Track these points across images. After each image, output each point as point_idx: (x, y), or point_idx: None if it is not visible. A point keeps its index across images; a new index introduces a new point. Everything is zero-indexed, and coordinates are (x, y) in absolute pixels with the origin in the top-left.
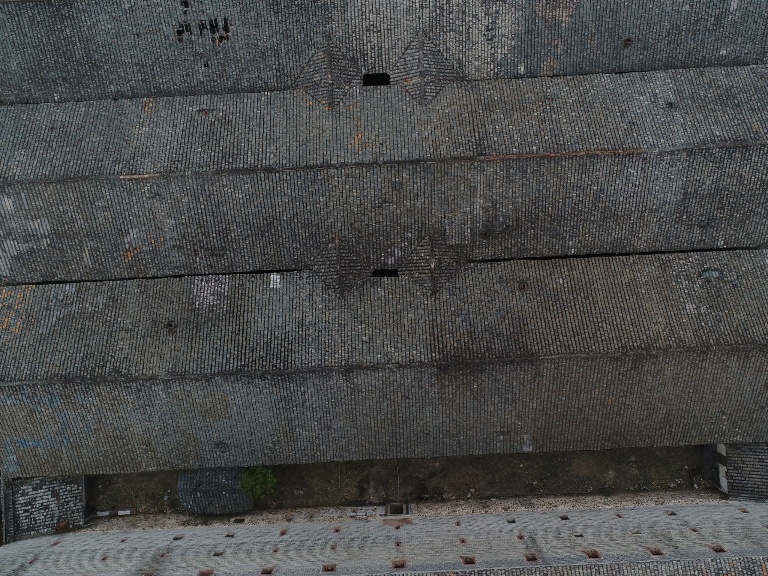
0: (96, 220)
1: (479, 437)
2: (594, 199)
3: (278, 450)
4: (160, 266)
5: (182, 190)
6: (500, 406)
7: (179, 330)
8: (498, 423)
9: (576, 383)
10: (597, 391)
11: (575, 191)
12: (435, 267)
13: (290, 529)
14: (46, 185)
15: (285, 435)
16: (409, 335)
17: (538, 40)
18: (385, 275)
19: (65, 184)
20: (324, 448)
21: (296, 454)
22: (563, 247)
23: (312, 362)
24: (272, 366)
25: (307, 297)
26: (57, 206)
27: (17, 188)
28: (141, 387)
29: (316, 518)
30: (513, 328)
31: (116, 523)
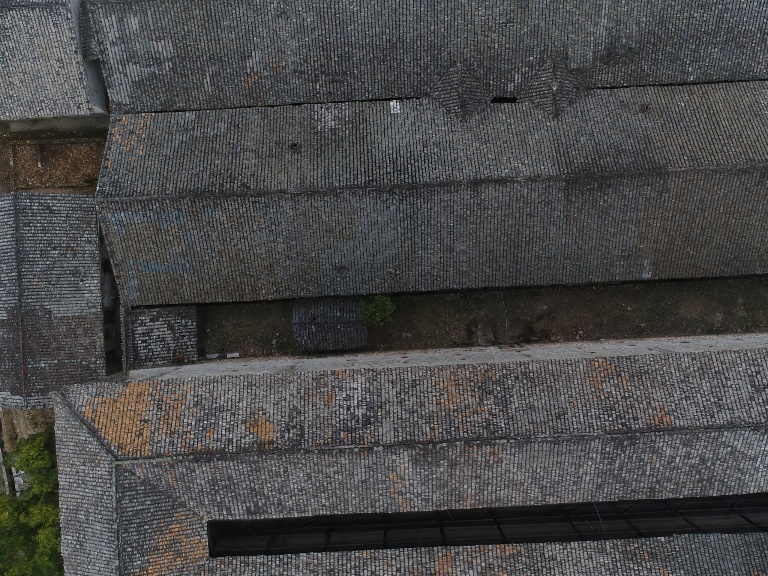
0: (220, 41)
1: (599, 262)
2: (718, 19)
3: (398, 276)
4: (280, 93)
5: (308, 8)
6: (624, 226)
7: (303, 150)
8: (620, 246)
9: (702, 200)
10: (722, 209)
11: (699, 10)
12: (557, 90)
13: (409, 356)
14: (173, 2)
15: (407, 259)
16: (535, 152)
17: None
18: (505, 101)
19: (192, 1)
20: (444, 274)
21: (416, 280)
22: (682, 73)
23: (440, 177)
24: (400, 181)
25: (429, 121)
26: (182, 26)
27: (144, 5)
28: (269, 203)
29: (431, 352)
30: (639, 145)
31: (229, 361)
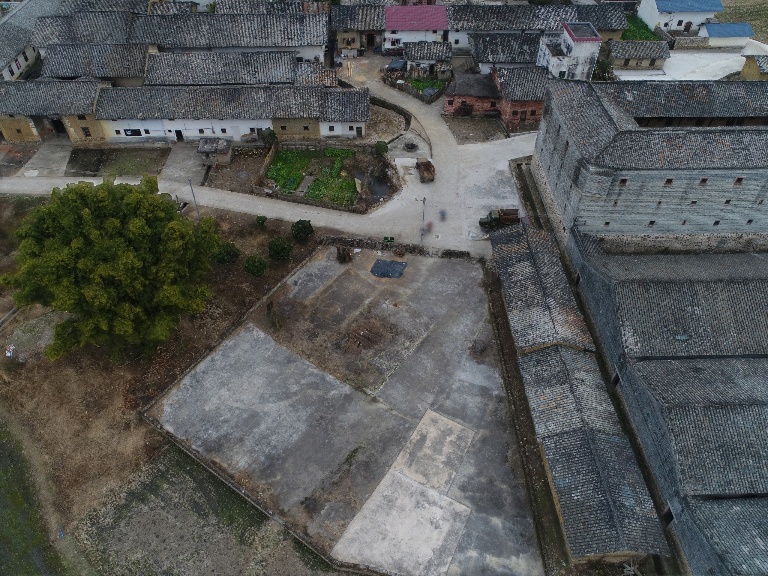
0: None
1: None
2: None
3: None
4: None
5: None
6: None
7: None
8: None
9: None
10: None
11: None
12: None
13: None
14: None
15: None
16: None
17: None
18: None
19: None
20: None
21: None
22: None
23: None
24: None
25: None
26: None
27: None
28: None
29: None
30: None
31: None
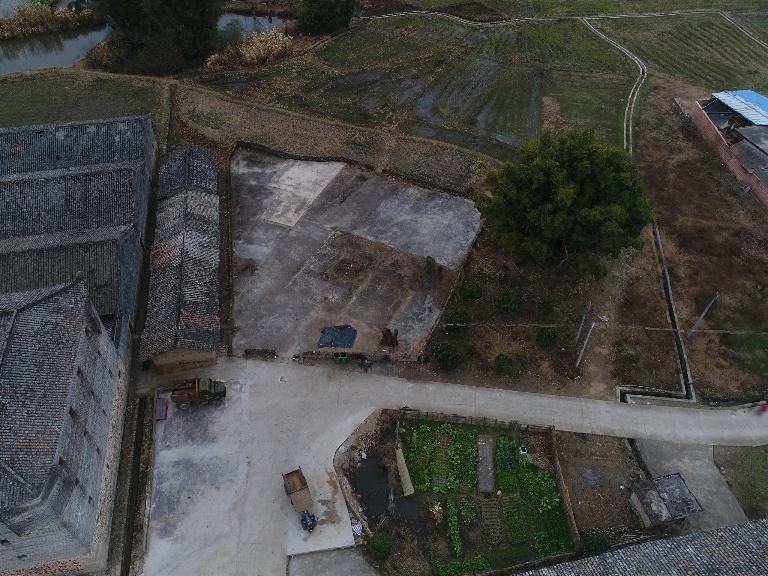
0: None
1: None
2: (7, 207)
3: None
4: None
5: None
6: None
7: None
8: None
9: None
10: None
11: None
12: None
13: None
14: None
15: None
16: None
17: (6, 160)
18: None
19: None
20: None
21: None
22: None
23: None
24: None
25: None
26: None
27: None
28: None
29: None
30: None
31: None
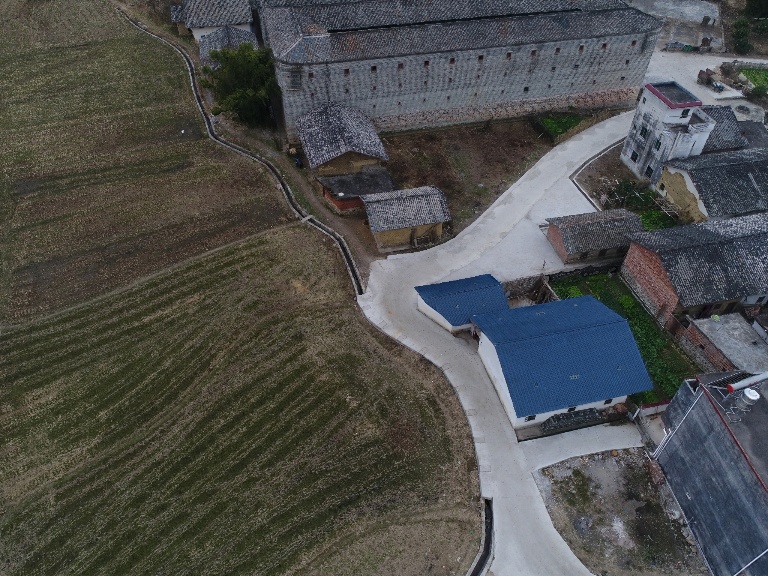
0: (302, 0)
1: None
2: None
3: None
4: None
5: None
6: None
7: None
8: None
9: None
10: None
11: None
12: None
13: None
14: None
15: None
16: None
17: None
18: None
19: None
20: None
21: None
22: None
23: None
24: None
25: None
26: None
27: None
28: None
29: None
30: None
31: None
